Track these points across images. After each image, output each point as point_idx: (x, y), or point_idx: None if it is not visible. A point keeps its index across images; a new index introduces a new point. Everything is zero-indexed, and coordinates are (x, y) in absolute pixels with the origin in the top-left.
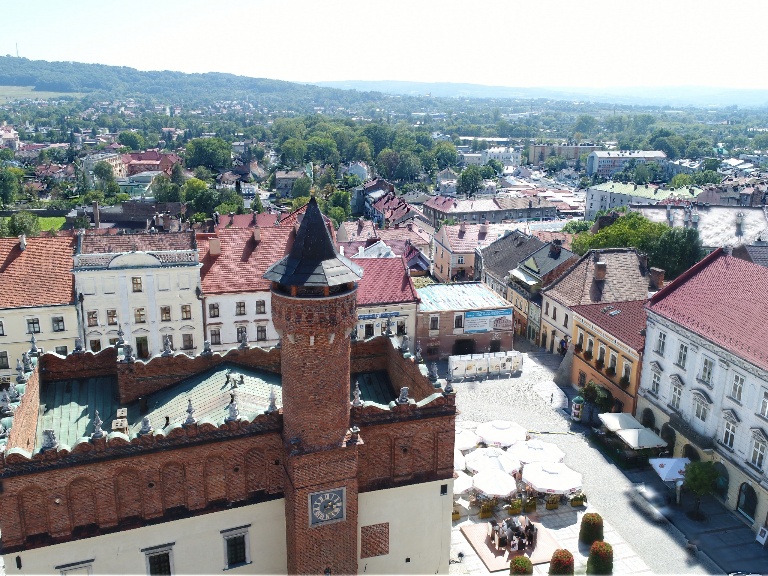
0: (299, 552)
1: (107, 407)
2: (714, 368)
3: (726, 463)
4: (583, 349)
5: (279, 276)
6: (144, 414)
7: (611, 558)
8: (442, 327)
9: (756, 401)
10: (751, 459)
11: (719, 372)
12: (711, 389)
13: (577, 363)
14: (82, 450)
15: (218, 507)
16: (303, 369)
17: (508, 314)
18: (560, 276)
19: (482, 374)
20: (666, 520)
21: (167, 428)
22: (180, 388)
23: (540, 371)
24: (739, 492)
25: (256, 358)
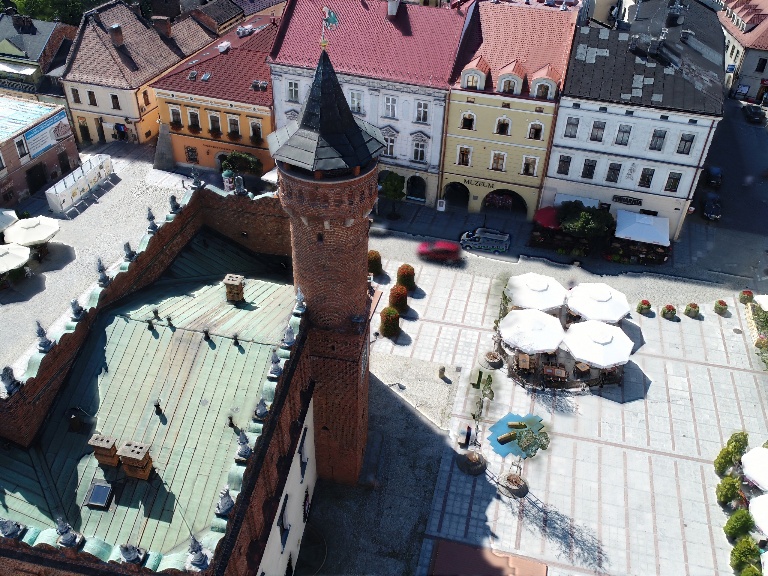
0: (358, 412)
1: (12, 465)
2: (364, 98)
3: (392, 169)
4: (184, 125)
5: (339, 161)
6: (89, 430)
7: (414, 273)
8: (8, 163)
9: (412, 112)
10: (414, 157)
11: (370, 100)
12: (364, 116)
13: (179, 141)
14: (242, 481)
15: (297, 433)
16: (357, 247)
17: (63, 118)
18: (70, 54)
19: (85, 195)
20: (385, 230)
21: (262, 396)
22: (83, 375)
23: (128, 165)
24: (407, 185)
25: (120, 286)
